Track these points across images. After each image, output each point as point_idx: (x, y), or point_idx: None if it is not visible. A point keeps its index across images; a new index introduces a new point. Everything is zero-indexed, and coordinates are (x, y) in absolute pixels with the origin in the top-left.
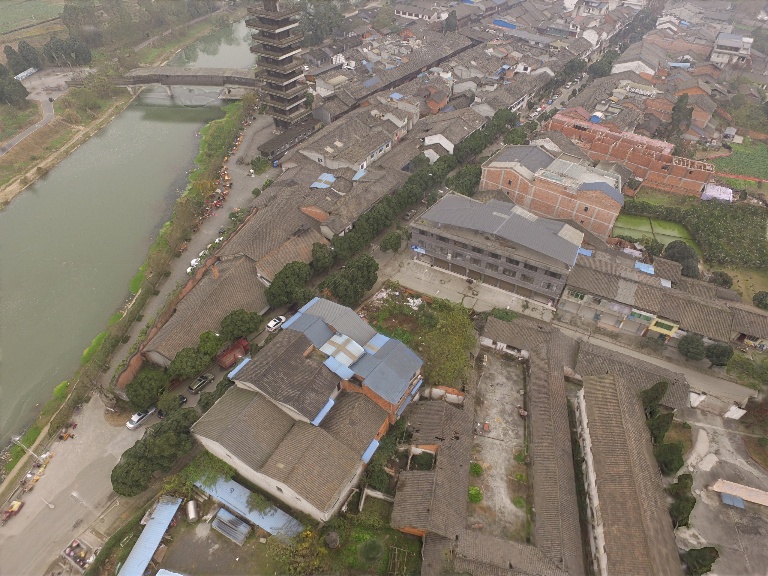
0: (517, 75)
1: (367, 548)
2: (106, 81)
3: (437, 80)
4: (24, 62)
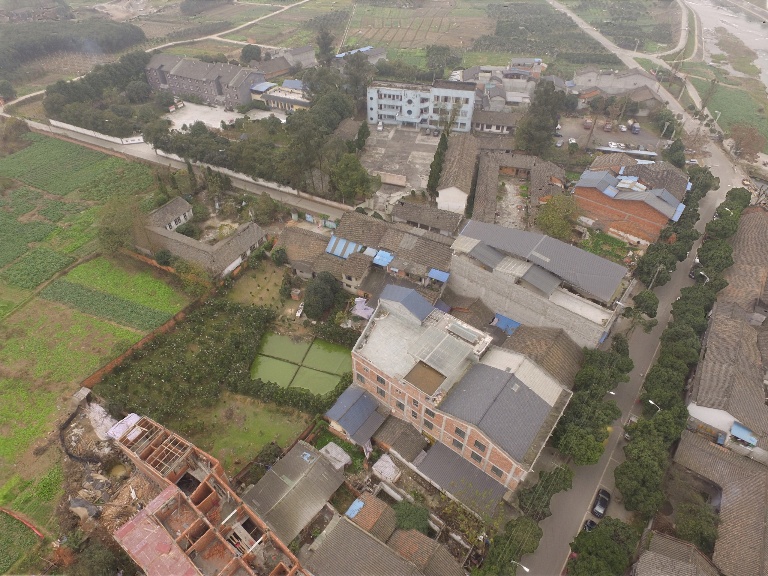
0: None
1: (576, 144)
2: None
3: None
4: None
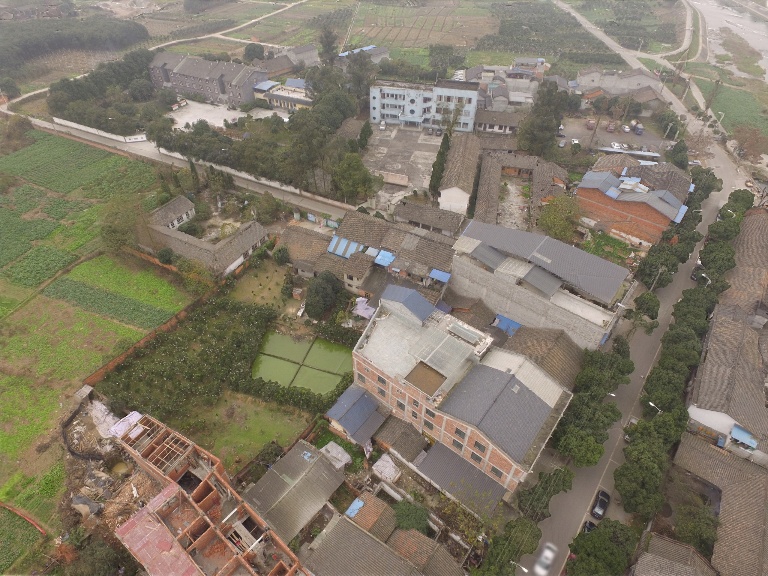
0: None
1: None
2: None
3: None
4: None
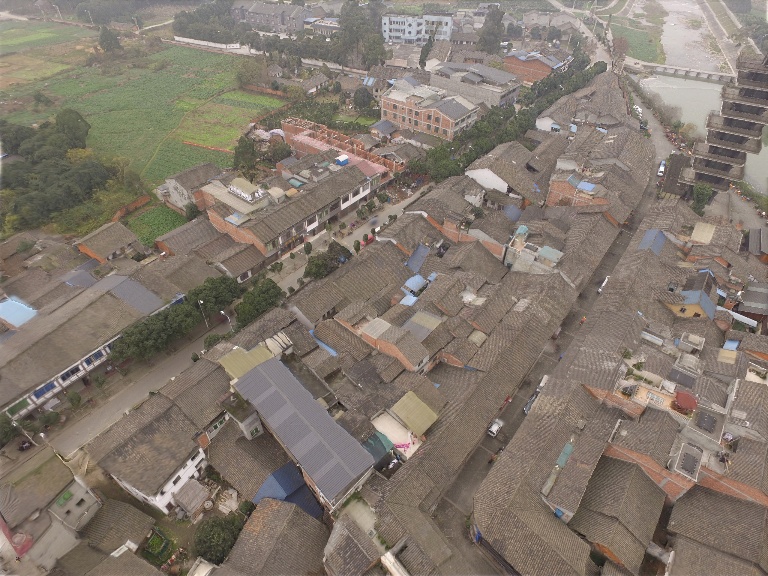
0: (386, 297)
1: None
2: None
3: (542, 233)
4: None
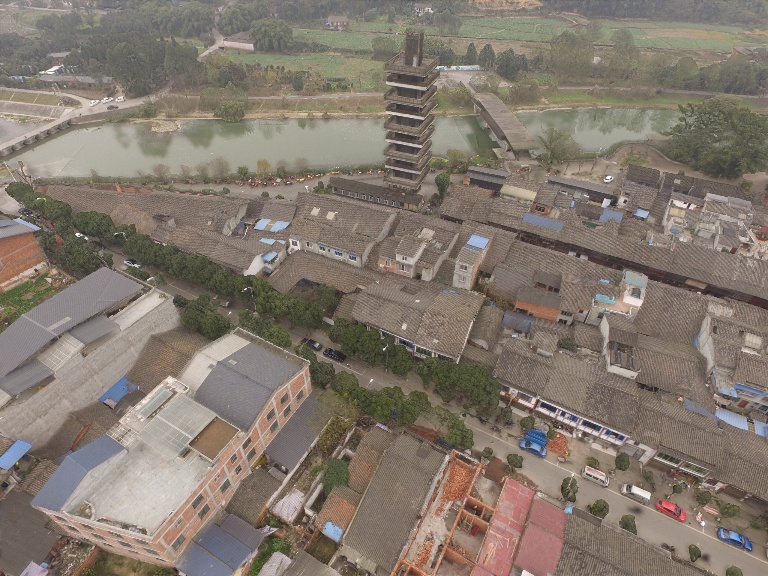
0: None
1: None
2: (465, 92)
3: None
4: (473, 59)
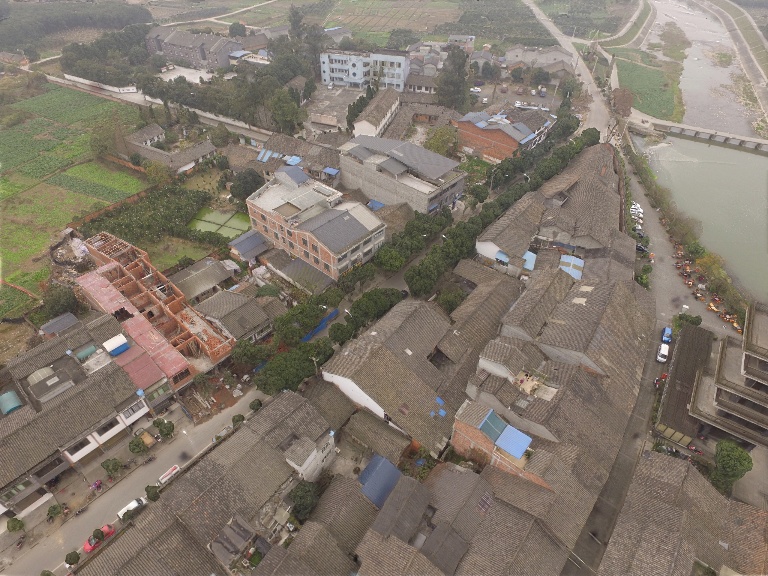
0: None
1: None
2: None
3: None
4: None
